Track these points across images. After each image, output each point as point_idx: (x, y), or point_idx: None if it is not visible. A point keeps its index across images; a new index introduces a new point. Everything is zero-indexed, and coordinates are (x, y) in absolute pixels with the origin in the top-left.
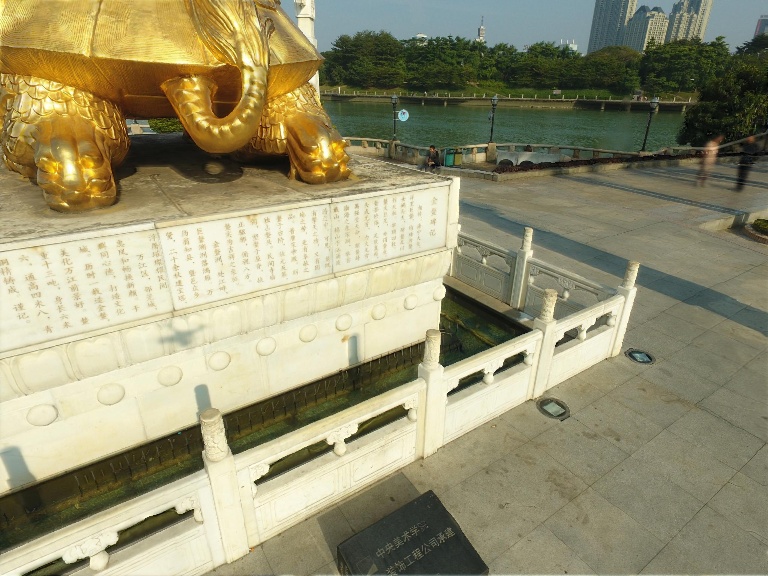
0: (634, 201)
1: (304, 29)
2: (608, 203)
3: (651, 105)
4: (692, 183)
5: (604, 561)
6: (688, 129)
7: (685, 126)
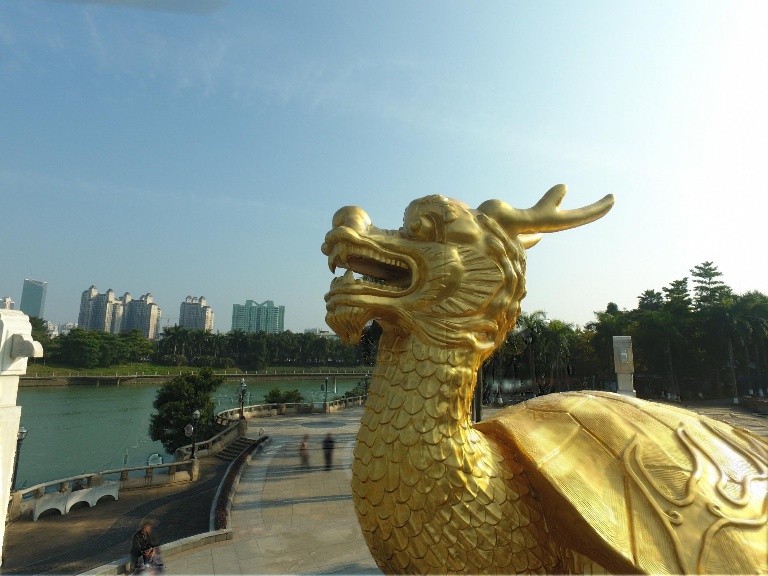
0: (347, 509)
1: (6, 394)
2: (348, 518)
3: (195, 416)
4: (309, 479)
5: None
6: (158, 426)
7: (151, 423)
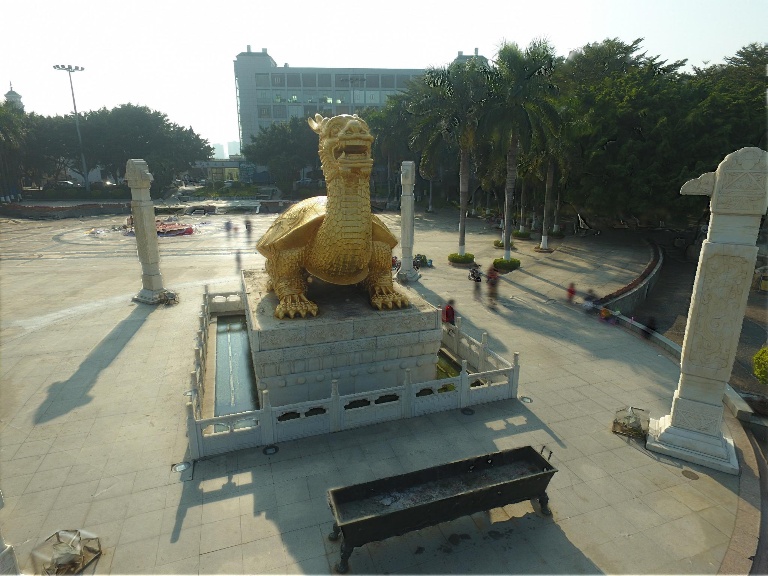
0: None
1: None
2: None
3: None
4: None
5: None
6: None
7: None
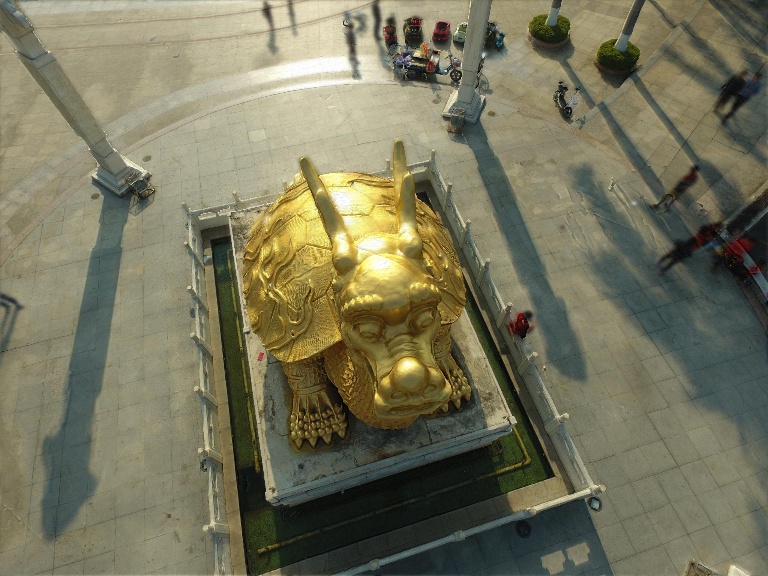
0: None
1: None
2: None
3: None
4: None
5: (273, 179)
6: None
7: None
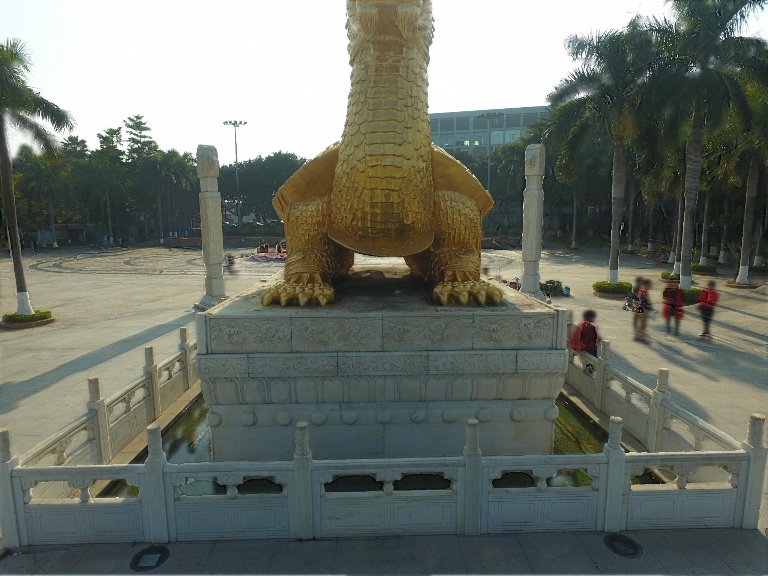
0: None
1: None
2: None
3: None
4: None
5: None
6: None
7: None
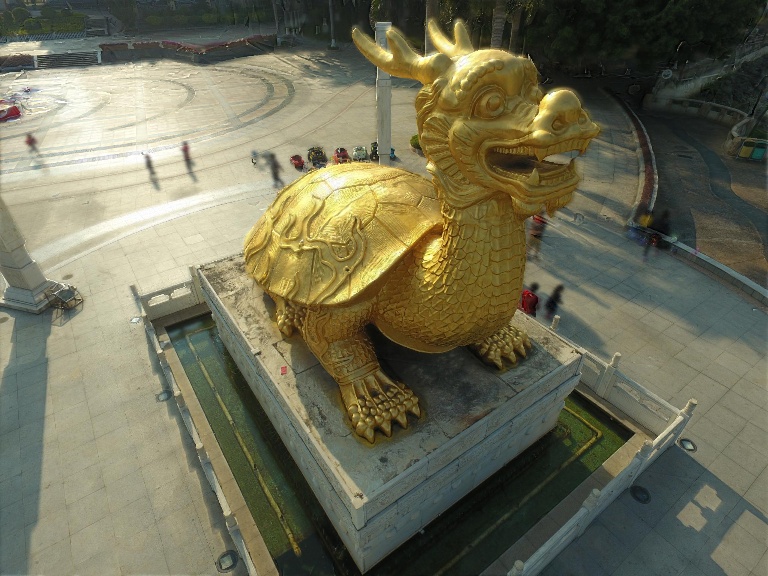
0: None
1: None
2: None
3: None
4: None
5: None
6: None
7: None
